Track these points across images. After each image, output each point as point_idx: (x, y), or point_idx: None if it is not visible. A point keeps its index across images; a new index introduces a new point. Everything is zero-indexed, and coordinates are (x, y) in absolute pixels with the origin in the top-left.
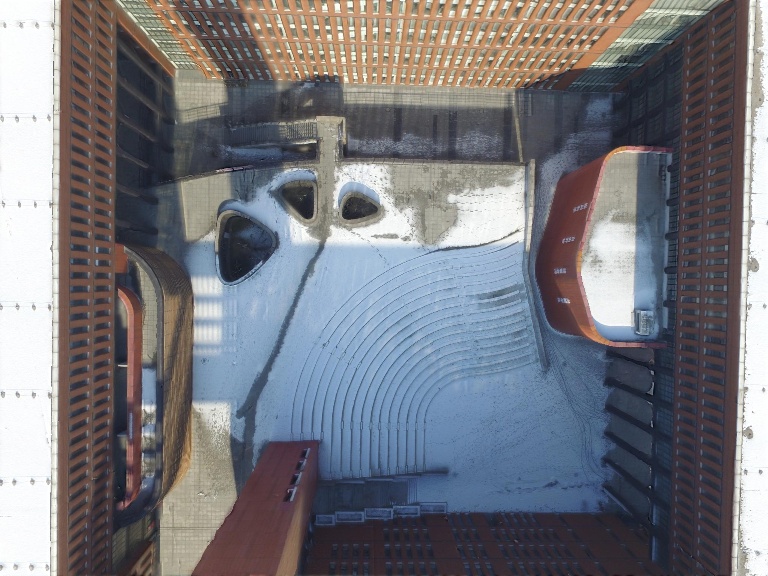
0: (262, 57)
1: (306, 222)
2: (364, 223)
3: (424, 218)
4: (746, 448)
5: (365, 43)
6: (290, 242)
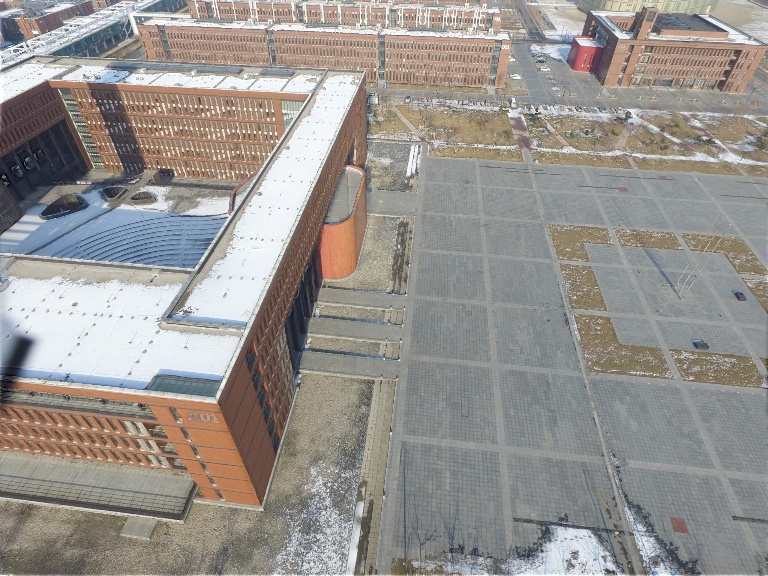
0: (131, 152)
1: (109, 200)
2: (142, 204)
3: (178, 205)
4: (255, 198)
5: (174, 138)
6: (94, 208)
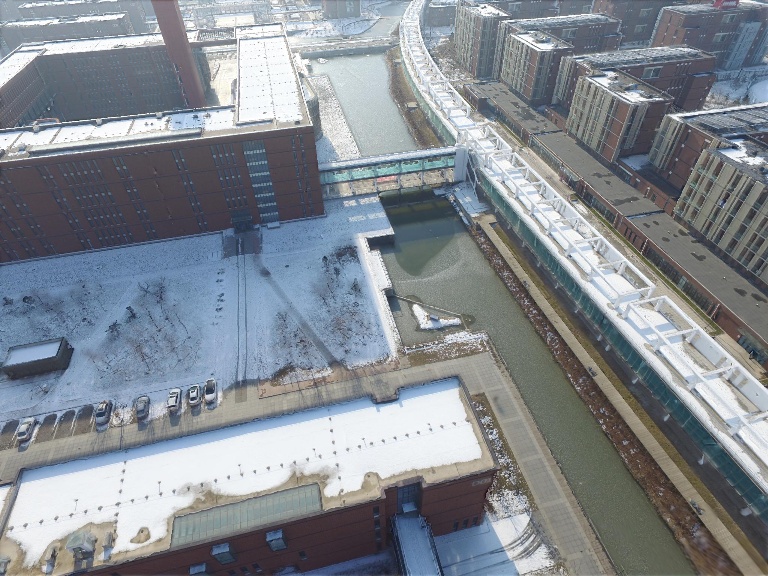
0: None
1: None
2: None
3: None
4: None
5: None
6: None
